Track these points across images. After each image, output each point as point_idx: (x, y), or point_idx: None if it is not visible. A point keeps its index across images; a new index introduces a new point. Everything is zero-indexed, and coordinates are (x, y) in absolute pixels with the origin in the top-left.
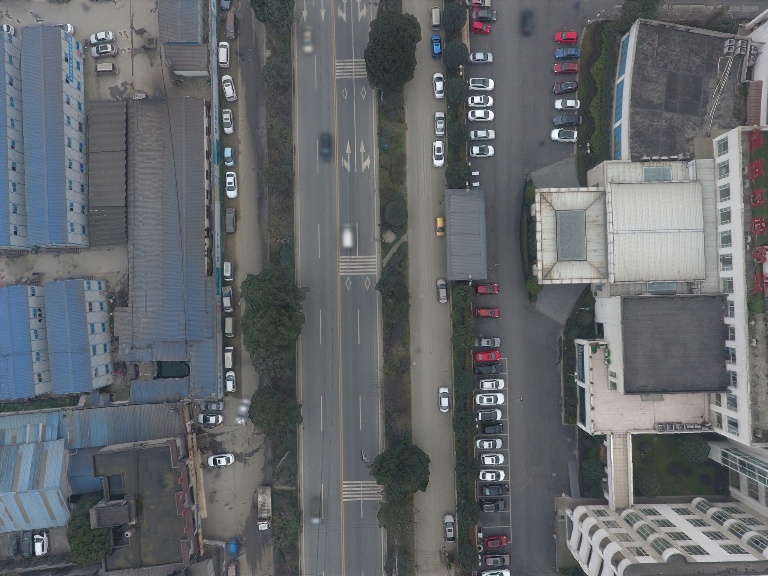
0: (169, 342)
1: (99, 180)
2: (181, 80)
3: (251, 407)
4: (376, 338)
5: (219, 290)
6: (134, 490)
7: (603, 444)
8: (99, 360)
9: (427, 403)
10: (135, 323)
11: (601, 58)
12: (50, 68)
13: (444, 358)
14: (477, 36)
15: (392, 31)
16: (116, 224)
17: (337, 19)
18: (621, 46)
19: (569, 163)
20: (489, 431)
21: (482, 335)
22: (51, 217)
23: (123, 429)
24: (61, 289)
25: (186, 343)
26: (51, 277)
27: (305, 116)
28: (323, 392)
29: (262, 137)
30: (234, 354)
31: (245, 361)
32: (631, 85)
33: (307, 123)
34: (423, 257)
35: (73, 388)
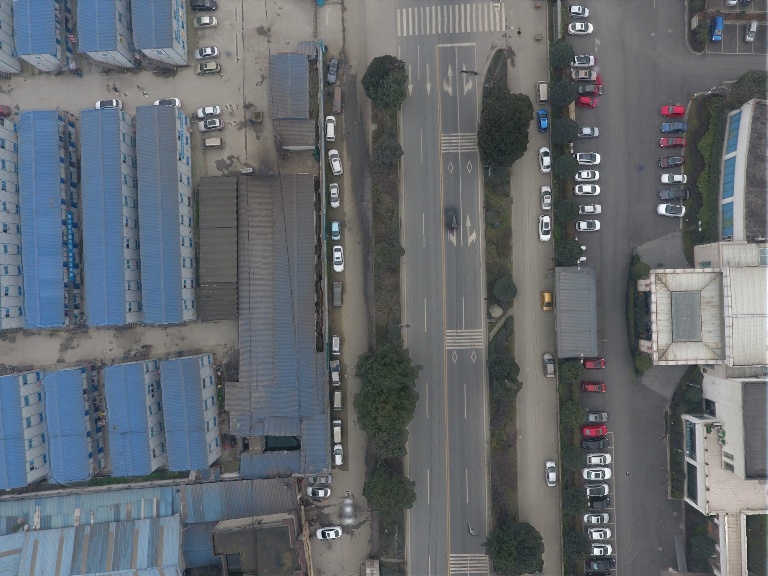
0: (280, 417)
1: (210, 256)
2: (287, 154)
3: (368, 487)
4: (482, 412)
5: (328, 364)
6: (253, 569)
7: (713, 521)
8: (211, 435)
9: (533, 476)
10: (246, 398)
11: (709, 133)
12: (166, 148)
13: (550, 432)
14: (582, 110)
15: (509, 113)
16: (227, 300)
17: (443, 93)
18: (729, 121)
19: (675, 237)
20: (597, 506)
21: (588, 409)
22: (167, 296)
23: (236, 504)
24: (178, 367)
25: (300, 421)
26: (159, 349)
27: (411, 190)
28: (430, 465)
29: (367, 210)
30: (342, 427)
31: (352, 434)
32: (745, 165)
33: (413, 197)
34: (529, 331)
35: (190, 466)
